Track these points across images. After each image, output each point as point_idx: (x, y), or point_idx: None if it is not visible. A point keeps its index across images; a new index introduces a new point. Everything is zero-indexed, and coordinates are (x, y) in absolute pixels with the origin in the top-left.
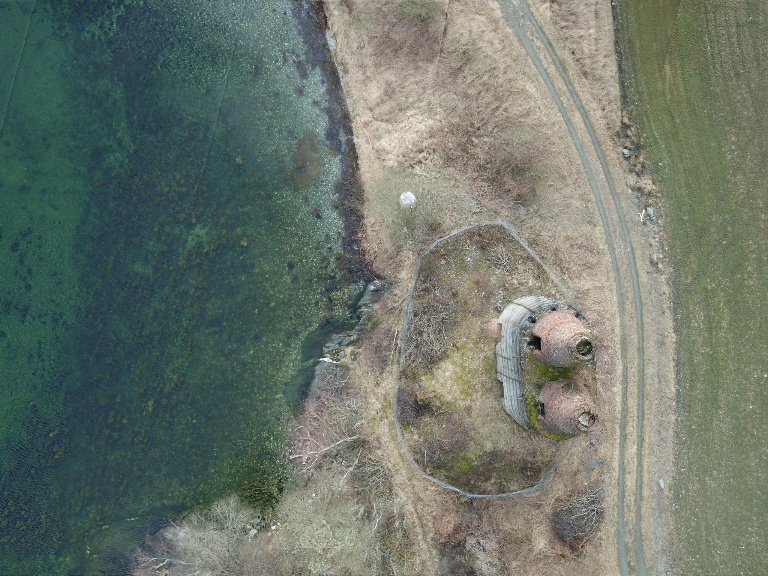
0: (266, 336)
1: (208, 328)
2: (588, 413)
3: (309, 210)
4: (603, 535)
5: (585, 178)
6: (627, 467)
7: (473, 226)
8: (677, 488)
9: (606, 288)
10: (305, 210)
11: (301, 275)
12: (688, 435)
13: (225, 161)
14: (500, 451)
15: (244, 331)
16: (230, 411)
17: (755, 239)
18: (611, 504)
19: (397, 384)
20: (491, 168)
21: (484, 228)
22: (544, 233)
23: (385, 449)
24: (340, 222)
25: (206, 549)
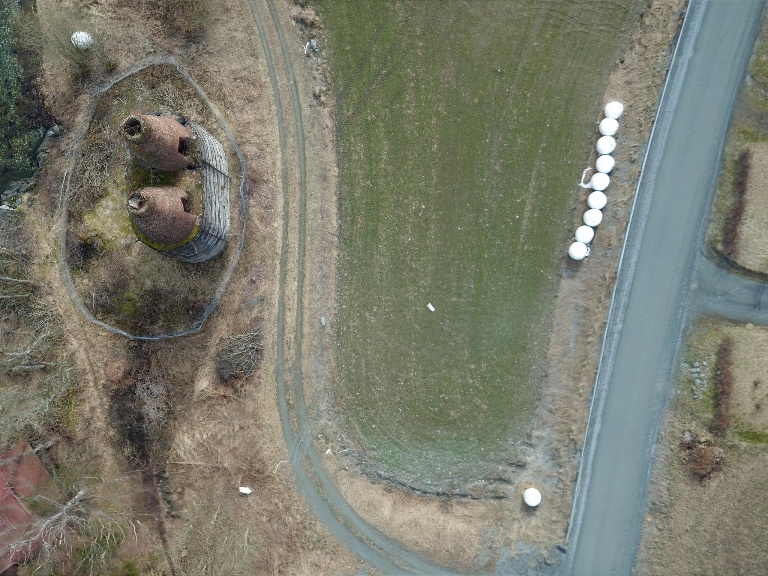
0: None
1: None
2: (137, 194)
3: None
4: (262, 373)
5: (248, 10)
6: (287, 303)
7: (147, 66)
8: (338, 325)
9: (267, 121)
10: None
11: None
12: (349, 271)
13: None
14: (161, 290)
15: None
16: None
17: (413, 67)
18: (270, 341)
19: (66, 227)
20: (163, 5)
21: (158, 68)
22: (210, 68)
23: (56, 295)
24: (19, 67)
25: None
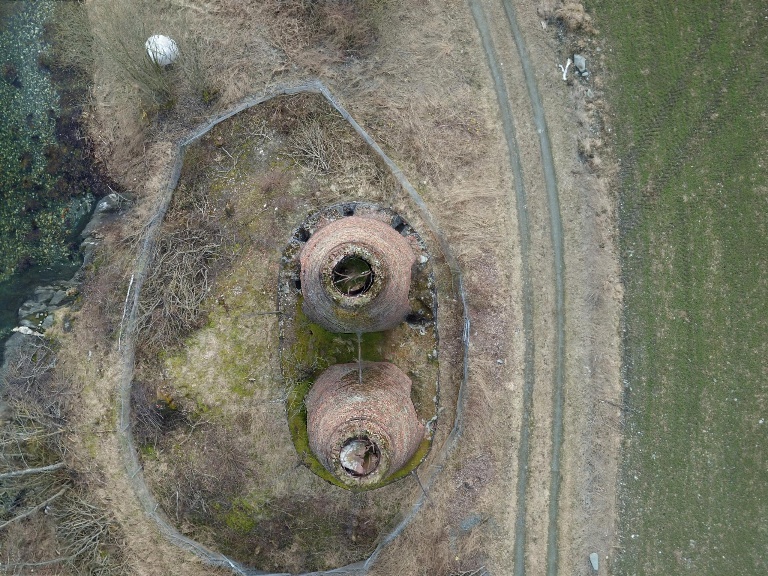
0: None
1: None
2: (361, 440)
3: (1, 72)
4: None
5: (463, 1)
6: (530, 530)
7: (273, 96)
8: (622, 569)
9: (497, 200)
10: None
11: None
12: (644, 472)
13: None
14: (301, 496)
15: None
16: None
17: None
18: None
19: (131, 373)
20: None
21: (292, 99)
22: (390, 103)
23: (111, 488)
24: (53, 93)
25: None
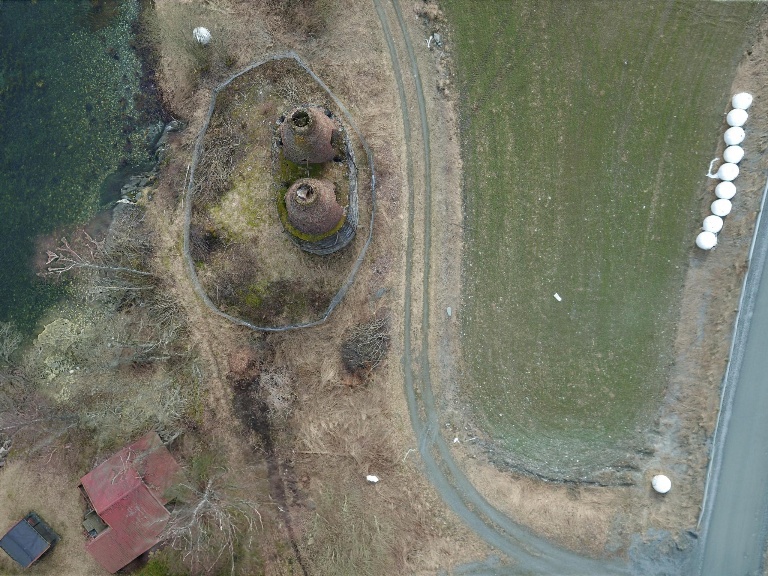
0: (64, 179)
1: (6, 172)
2: (305, 185)
3: (106, 50)
4: (390, 363)
5: (372, 4)
6: (413, 294)
7: (267, 61)
8: (464, 315)
9: (392, 114)
10: (102, 51)
11: (99, 117)
12: (475, 261)
13: (22, 2)
14: (288, 282)
15: (43, 175)
16: (29, 256)
17: (538, 60)
18: (397, 332)
19: (189, 220)
20: (283, 1)
21: (278, 63)
22: (333, 63)
23: (179, 287)
24: (138, 62)
25: (1, 392)
